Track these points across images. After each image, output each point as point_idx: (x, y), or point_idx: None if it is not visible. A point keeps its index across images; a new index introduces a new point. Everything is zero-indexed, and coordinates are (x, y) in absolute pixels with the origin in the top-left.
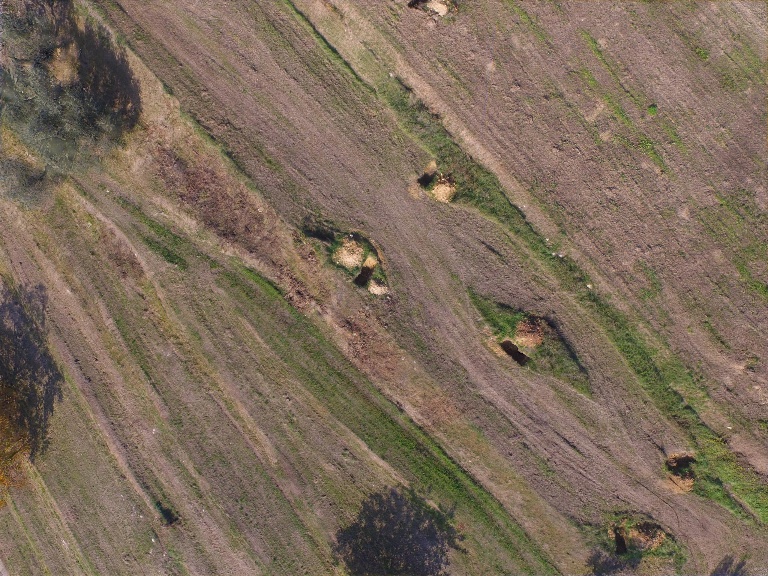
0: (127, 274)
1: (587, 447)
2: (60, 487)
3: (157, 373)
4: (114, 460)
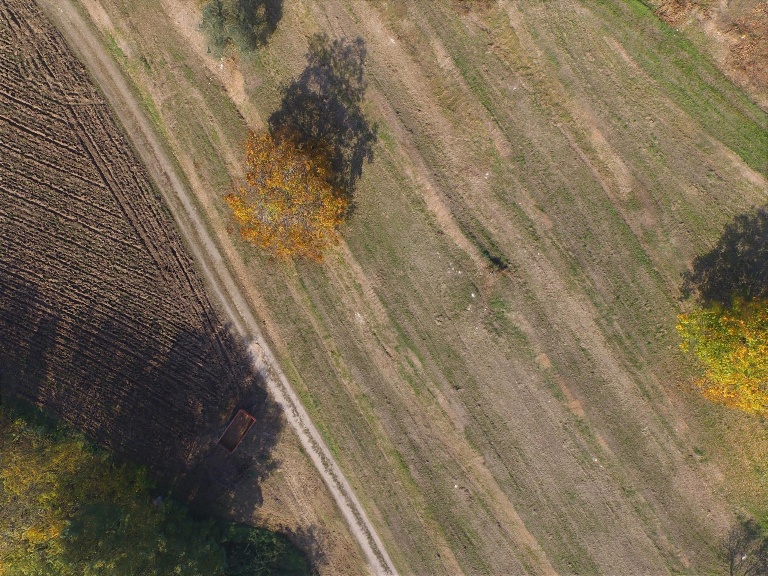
0: (470, 9)
1: None
2: (366, 252)
3: (500, 109)
4: (431, 216)
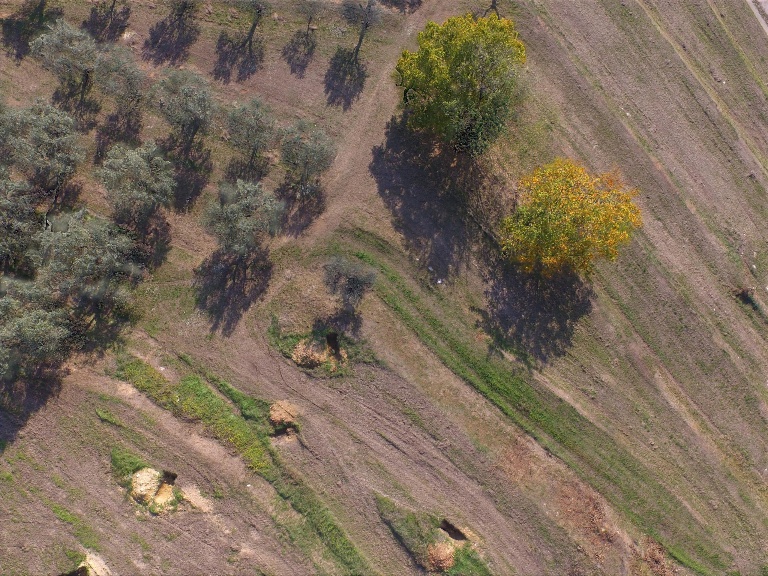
0: None
1: (375, 442)
2: None
3: None
4: None
